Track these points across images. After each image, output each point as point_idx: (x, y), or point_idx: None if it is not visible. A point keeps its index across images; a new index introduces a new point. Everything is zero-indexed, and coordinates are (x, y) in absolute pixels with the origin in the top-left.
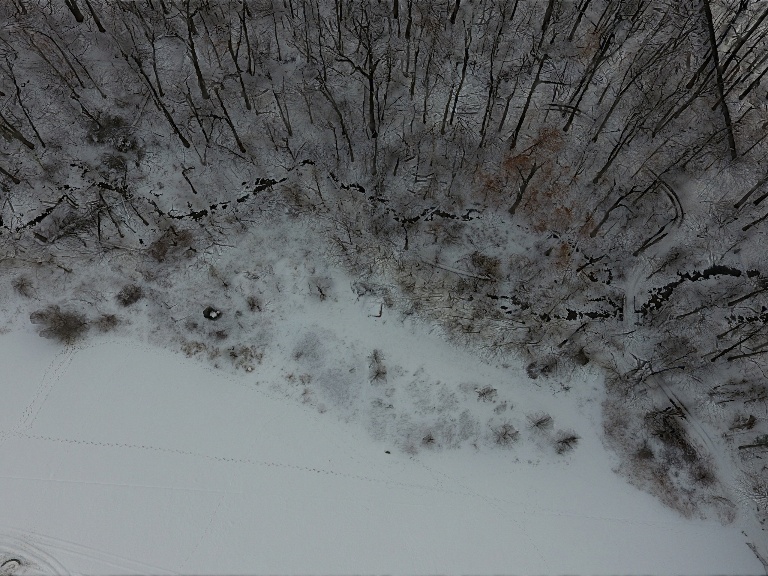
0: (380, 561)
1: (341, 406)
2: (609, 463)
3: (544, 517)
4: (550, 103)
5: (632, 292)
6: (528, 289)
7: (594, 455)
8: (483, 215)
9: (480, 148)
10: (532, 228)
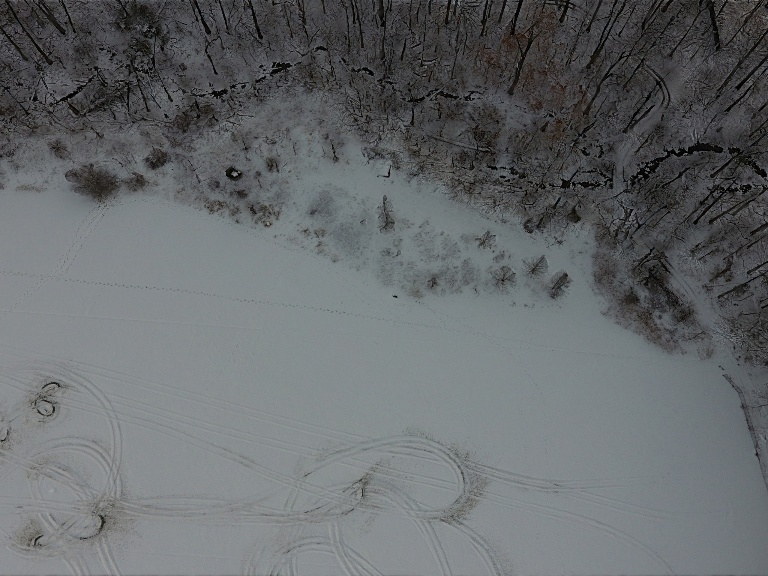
0: (388, 387)
1: (352, 256)
2: (598, 307)
3: (538, 352)
4: None
5: (621, 164)
6: (525, 161)
7: (585, 300)
8: (484, 96)
9: (481, 37)
10: (529, 107)
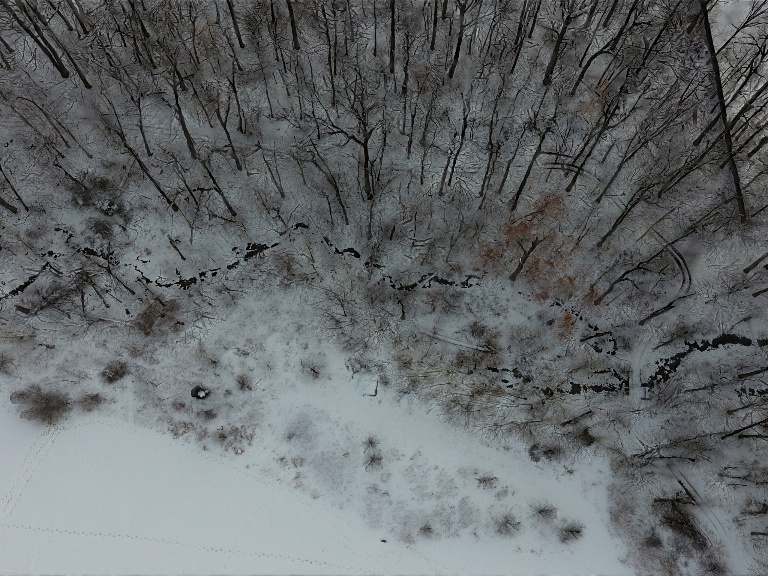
0: None
1: (335, 491)
2: (615, 552)
3: None
4: (552, 161)
5: (638, 364)
6: (530, 361)
7: (600, 543)
8: (483, 282)
9: (479, 210)
10: (534, 296)
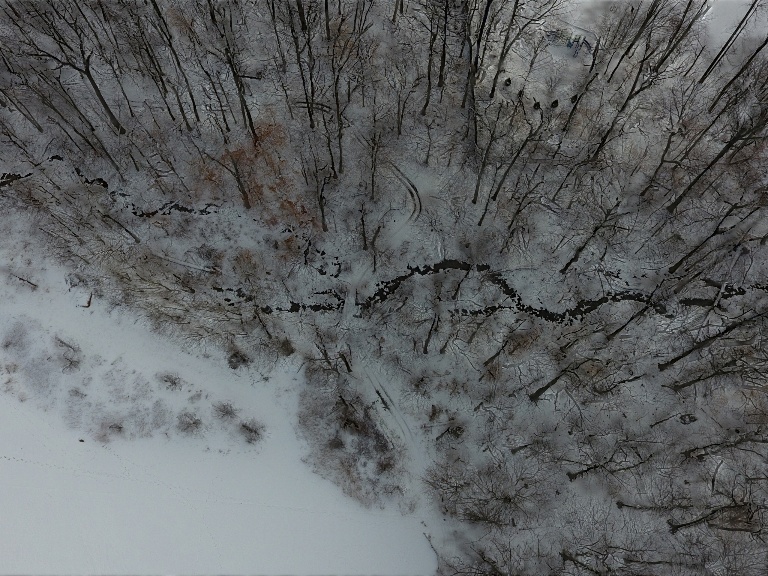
0: (53, 548)
1: (41, 395)
2: (299, 453)
3: (225, 506)
4: (302, 101)
5: (357, 285)
6: (253, 282)
7: (286, 445)
8: (220, 209)
9: (226, 144)
10: (264, 222)
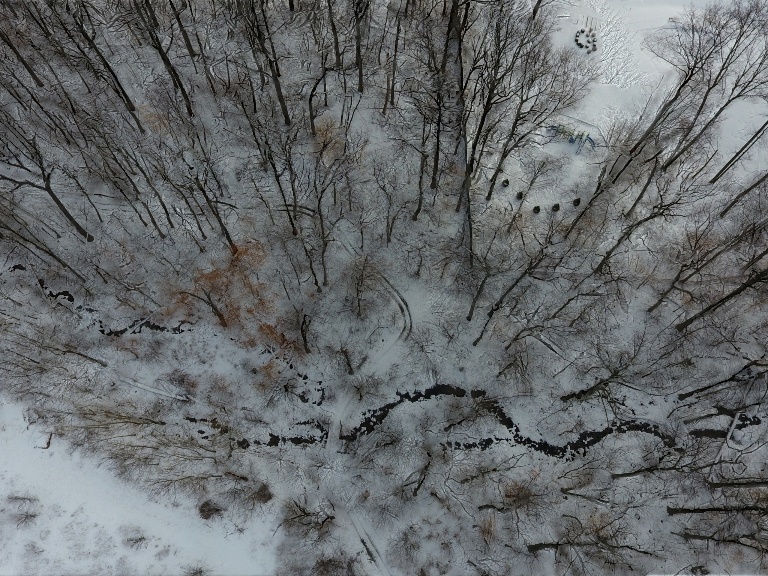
0: None
1: None
2: None
3: None
4: (284, 203)
5: (341, 415)
6: (229, 411)
7: None
8: (195, 327)
9: (202, 253)
10: (242, 343)
